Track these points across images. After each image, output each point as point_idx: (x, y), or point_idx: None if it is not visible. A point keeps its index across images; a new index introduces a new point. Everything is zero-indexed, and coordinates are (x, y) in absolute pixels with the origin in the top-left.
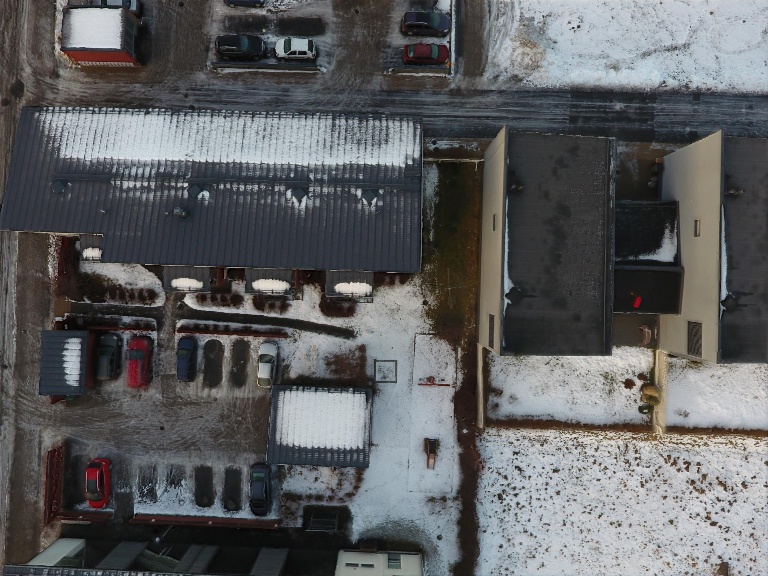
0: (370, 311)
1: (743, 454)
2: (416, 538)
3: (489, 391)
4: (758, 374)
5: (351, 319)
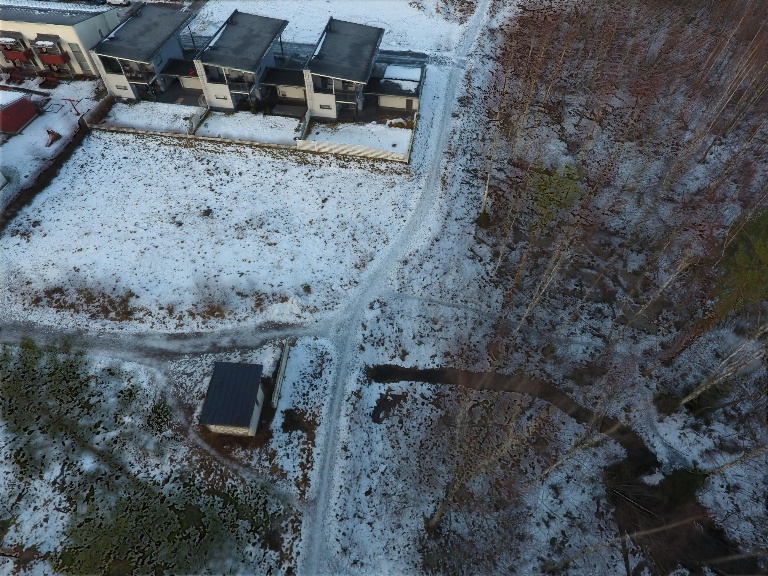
0: (65, 88)
1: (245, 160)
2: (11, 175)
3: (104, 115)
4: (262, 121)
5: (52, 90)
